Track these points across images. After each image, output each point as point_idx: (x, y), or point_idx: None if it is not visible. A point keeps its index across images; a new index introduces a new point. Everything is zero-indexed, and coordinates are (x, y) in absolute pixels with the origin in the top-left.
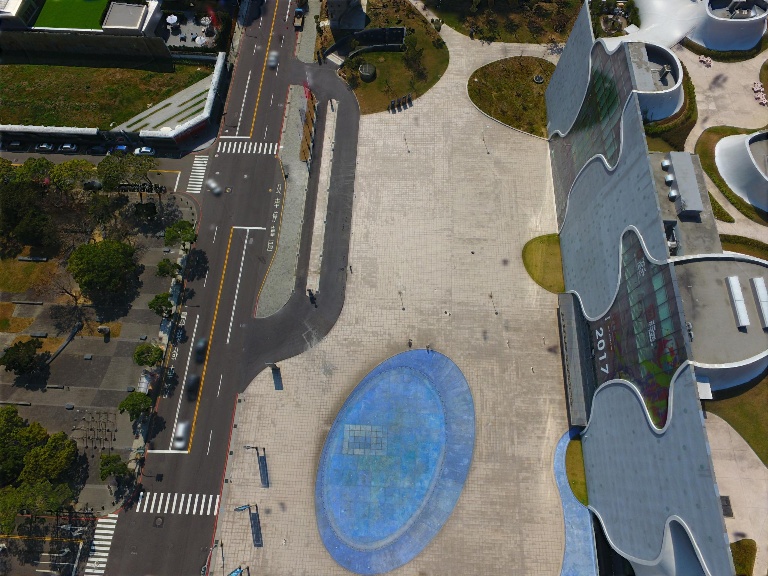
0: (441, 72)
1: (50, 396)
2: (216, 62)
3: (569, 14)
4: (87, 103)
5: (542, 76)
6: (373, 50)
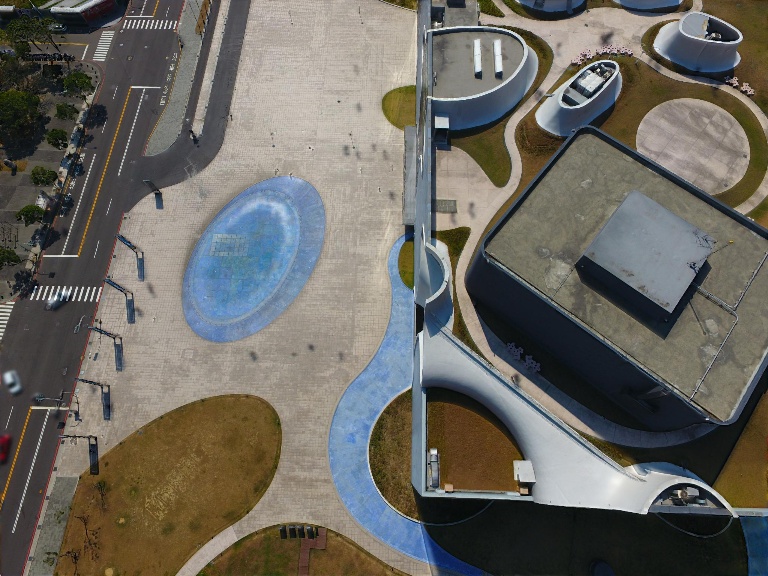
0: None
1: None
2: None
3: None
4: None
5: None
6: None
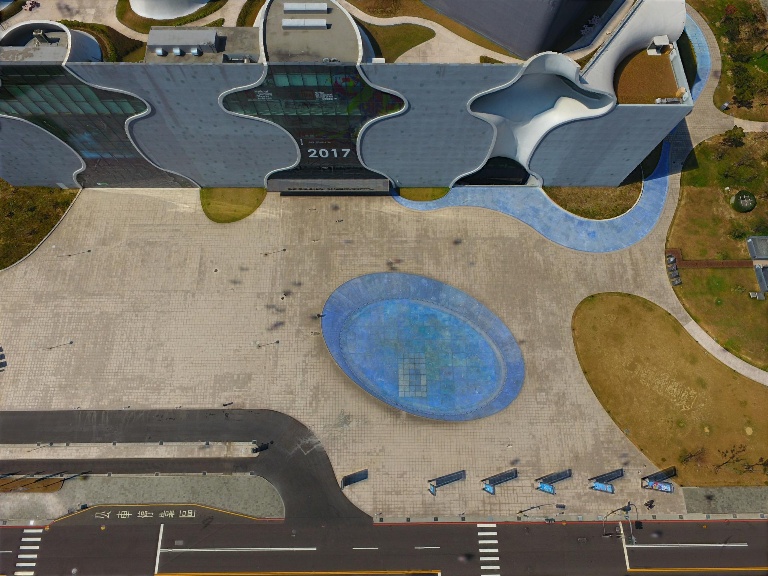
0: None
1: None
2: None
3: None
4: None
5: None
6: None
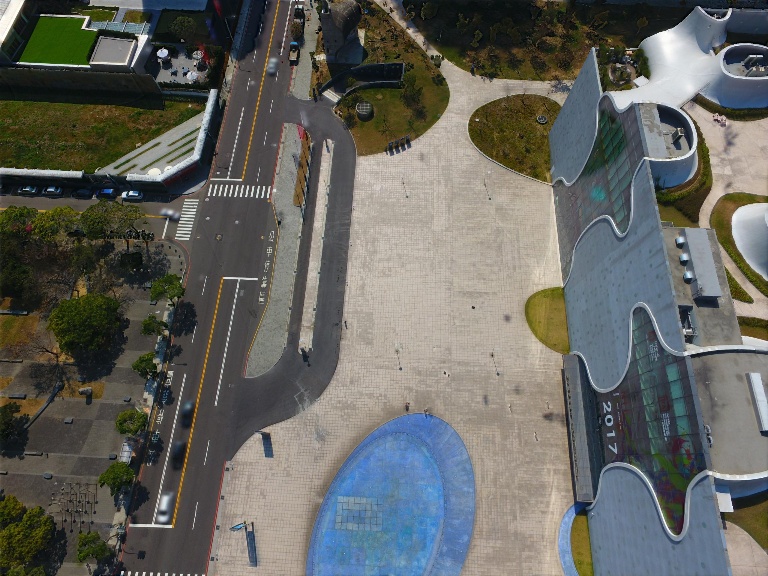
0: (441, 111)
1: (28, 464)
2: (207, 100)
3: (573, 49)
4: (73, 143)
5: (546, 116)
6: (371, 87)
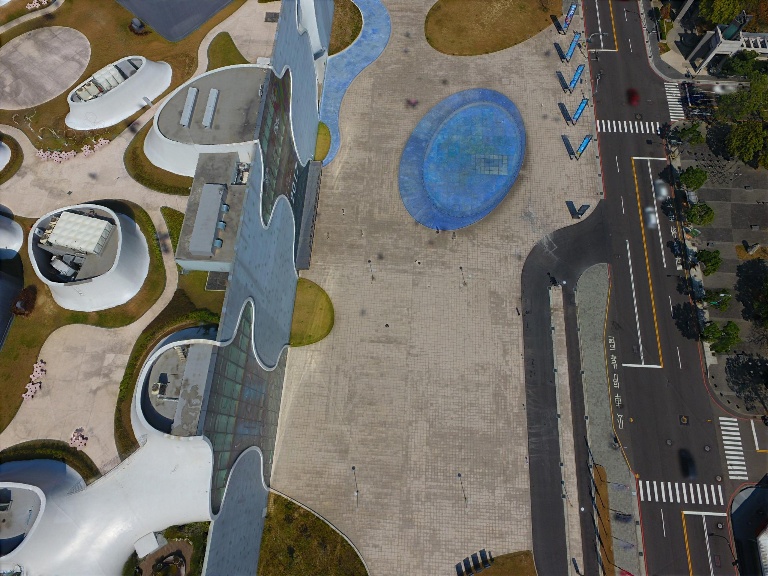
0: None
1: None
2: None
3: None
4: None
5: None
6: None
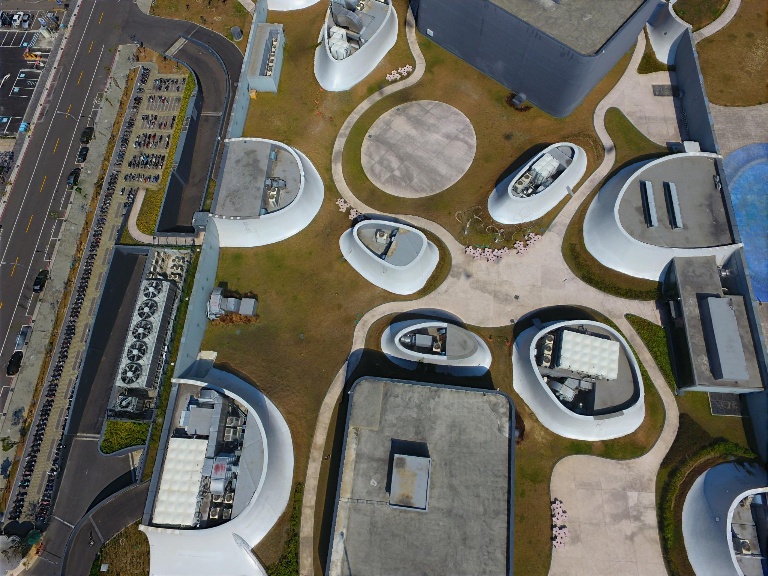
0: None
1: None
2: None
3: None
4: None
5: None
6: None
